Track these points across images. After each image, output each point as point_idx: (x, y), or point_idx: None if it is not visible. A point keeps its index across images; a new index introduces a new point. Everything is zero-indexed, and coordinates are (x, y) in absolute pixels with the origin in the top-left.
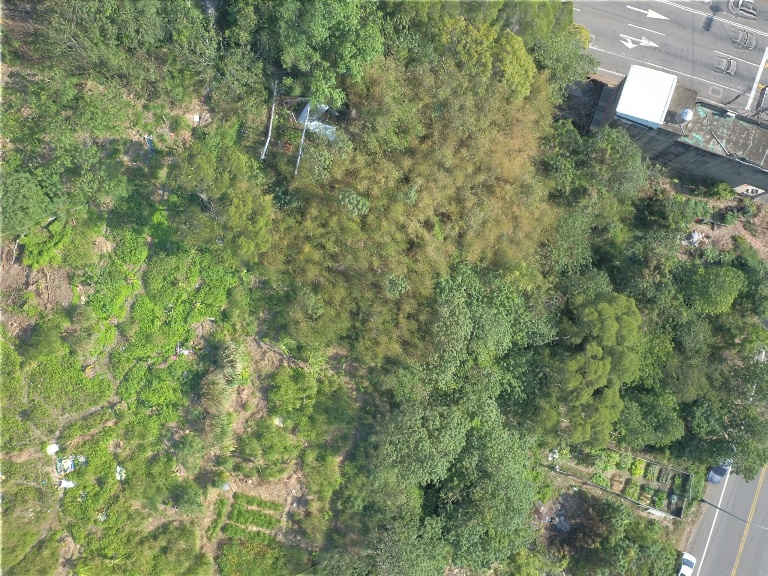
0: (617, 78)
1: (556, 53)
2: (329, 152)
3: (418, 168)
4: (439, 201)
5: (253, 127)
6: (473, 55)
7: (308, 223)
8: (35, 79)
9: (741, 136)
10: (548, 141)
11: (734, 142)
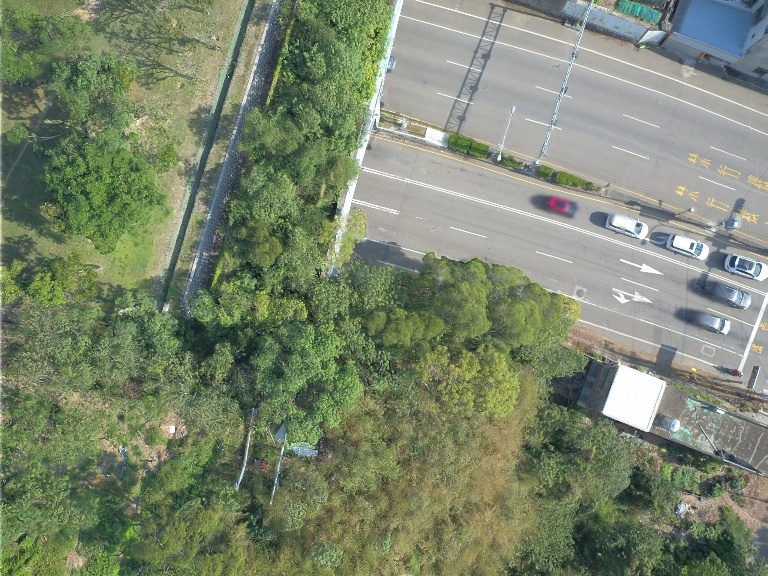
0: (608, 333)
1: (543, 354)
2: (304, 502)
3: (395, 506)
4: (416, 538)
5: (229, 445)
6: (454, 396)
7: (281, 564)
8: (9, 384)
9: (730, 432)
10: (533, 431)
11: (723, 438)
